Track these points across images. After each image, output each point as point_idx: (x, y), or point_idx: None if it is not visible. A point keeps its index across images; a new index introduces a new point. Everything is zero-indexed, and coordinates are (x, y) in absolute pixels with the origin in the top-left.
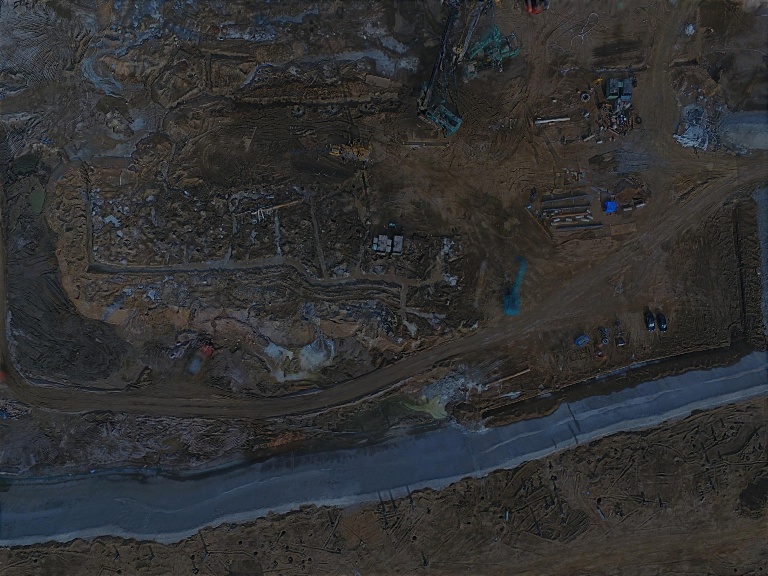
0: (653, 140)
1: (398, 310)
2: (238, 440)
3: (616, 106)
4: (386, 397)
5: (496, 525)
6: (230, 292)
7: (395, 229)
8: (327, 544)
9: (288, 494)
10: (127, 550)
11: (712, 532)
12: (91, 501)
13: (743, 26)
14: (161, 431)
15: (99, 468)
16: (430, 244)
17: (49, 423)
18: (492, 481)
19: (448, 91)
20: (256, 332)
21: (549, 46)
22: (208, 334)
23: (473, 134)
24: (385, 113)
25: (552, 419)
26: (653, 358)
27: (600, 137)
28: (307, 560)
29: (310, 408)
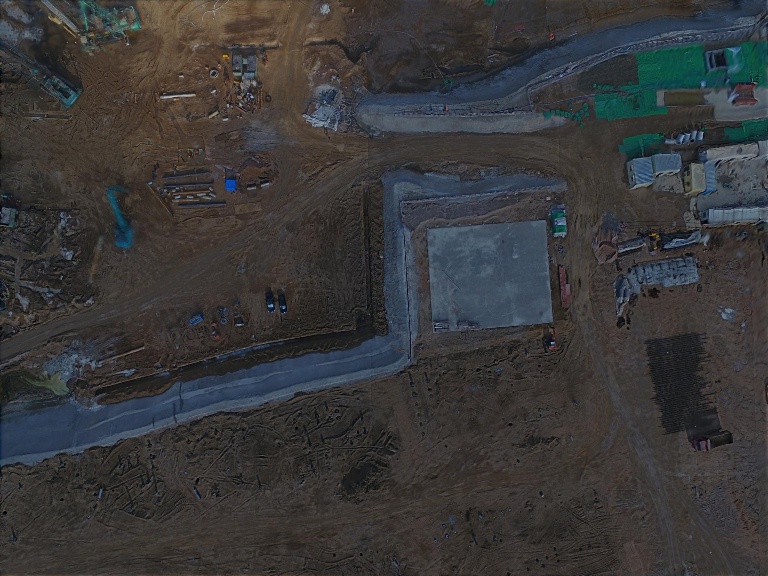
0: (282, 119)
1: (11, 283)
2: None
3: (240, 83)
4: (6, 371)
5: (89, 502)
6: None
7: (10, 201)
8: None
9: None
10: None
11: (311, 516)
12: None
13: (390, 7)
14: None
15: None
16: (47, 217)
17: None
18: (88, 458)
19: (73, 63)
20: None
21: (179, 21)
22: None
23: (97, 107)
24: (4, 83)
25: (161, 398)
26: (274, 339)
27: (228, 114)
28: None
29: None
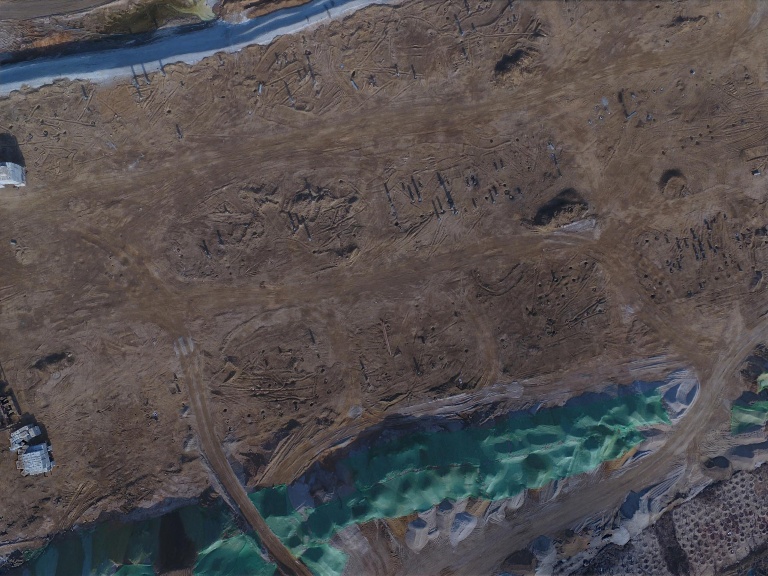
0: None
1: None
2: (5, 41)
3: None
4: None
5: (250, 98)
6: None
7: None
8: (81, 117)
9: (44, 72)
10: None
11: (467, 103)
12: None
13: None
14: None
15: None
16: None
17: None
18: (245, 56)
19: None
20: None
21: None
22: None
23: None
24: None
25: (310, 4)
26: None
27: None
28: (62, 133)
29: (76, 9)
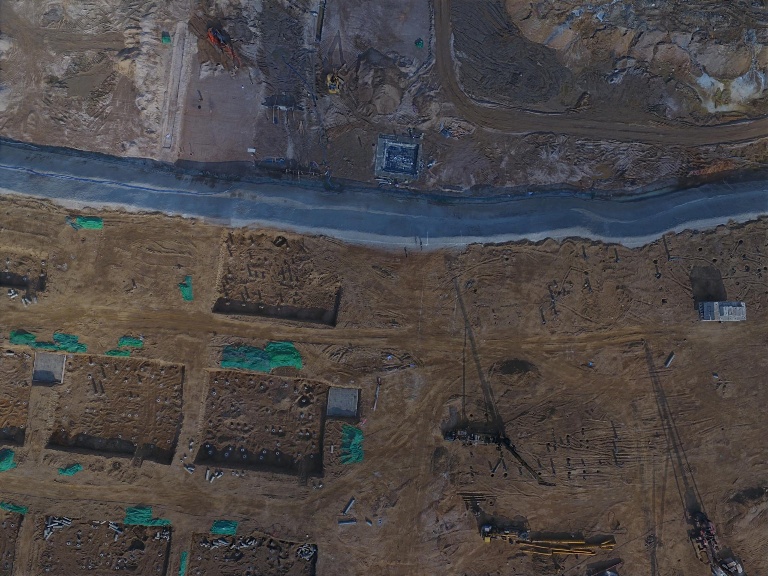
0: None
1: None
2: (672, 166)
3: None
4: None
5: None
6: (676, 16)
7: None
8: None
9: (742, 207)
10: (594, 252)
11: None
12: (547, 211)
13: None
14: (597, 156)
15: (537, 190)
16: None
17: (491, 143)
18: None
19: None
20: (692, 61)
21: None
22: (646, 61)
23: None
24: None
25: None
26: None
27: None
28: (763, 269)
29: (741, 138)
